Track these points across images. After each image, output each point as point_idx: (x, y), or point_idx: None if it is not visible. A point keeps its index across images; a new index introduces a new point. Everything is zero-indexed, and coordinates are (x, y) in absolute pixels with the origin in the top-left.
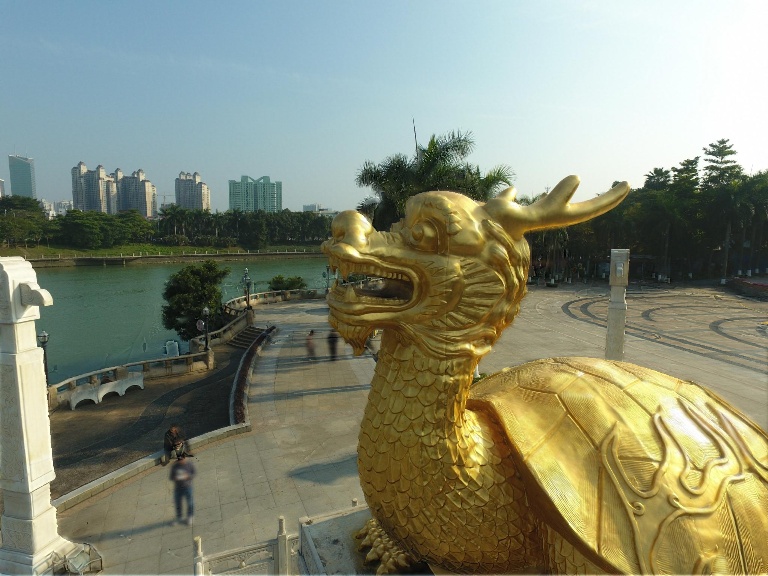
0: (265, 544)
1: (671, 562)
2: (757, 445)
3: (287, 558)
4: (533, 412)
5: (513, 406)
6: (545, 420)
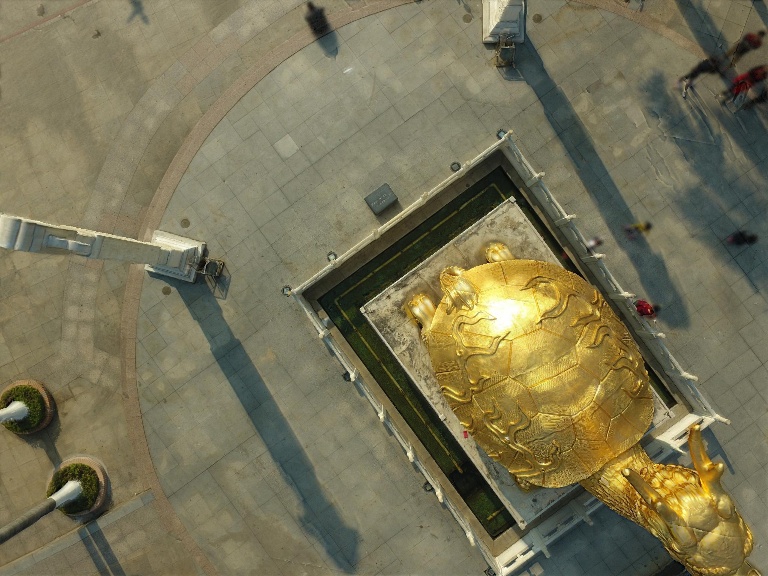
0: (478, 544)
1: (643, 370)
2: (579, 306)
3: (468, 525)
4: (620, 431)
5: (619, 442)
6: (624, 425)
